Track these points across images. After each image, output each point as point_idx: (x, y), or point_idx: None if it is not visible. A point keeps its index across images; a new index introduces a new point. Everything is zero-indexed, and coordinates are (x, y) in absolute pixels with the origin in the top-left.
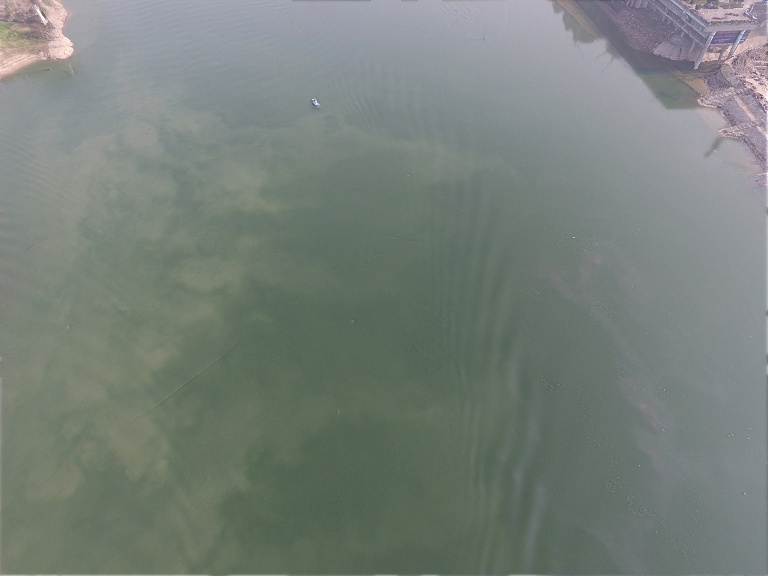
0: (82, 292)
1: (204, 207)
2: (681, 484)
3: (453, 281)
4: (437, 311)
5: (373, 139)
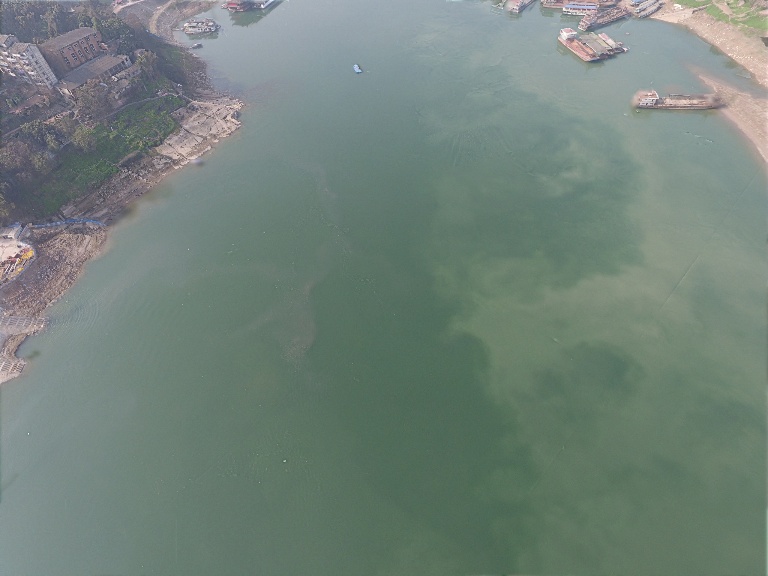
0: None
1: None
2: (300, 236)
3: (453, 377)
4: (469, 333)
5: None
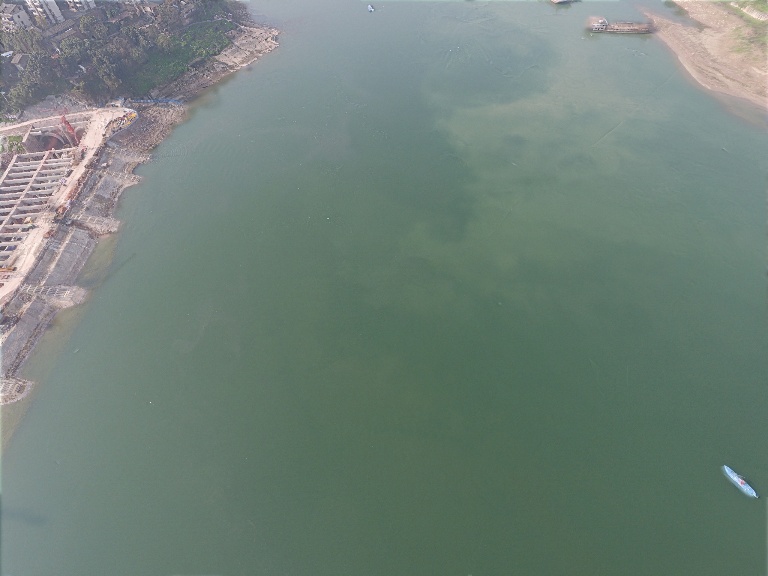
0: (748, 170)
1: (730, 254)
2: (330, 110)
3: (441, 178)
4: (453, 155)
5: (574, 377)
